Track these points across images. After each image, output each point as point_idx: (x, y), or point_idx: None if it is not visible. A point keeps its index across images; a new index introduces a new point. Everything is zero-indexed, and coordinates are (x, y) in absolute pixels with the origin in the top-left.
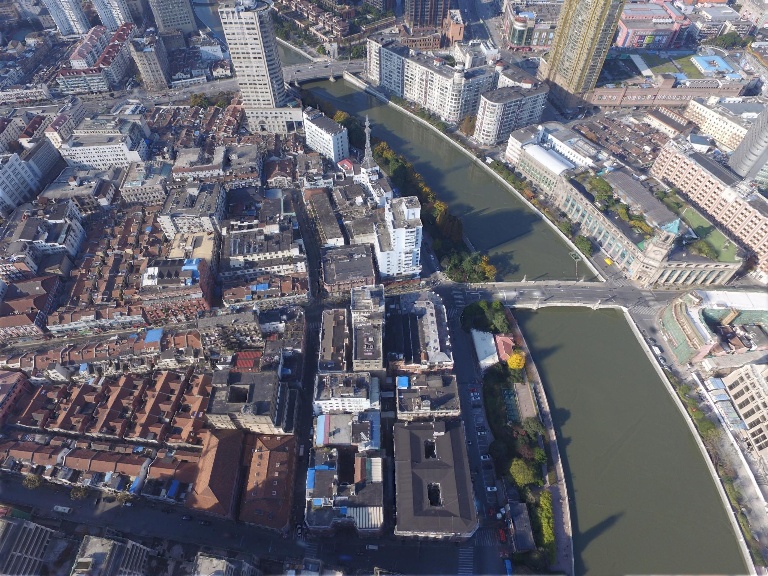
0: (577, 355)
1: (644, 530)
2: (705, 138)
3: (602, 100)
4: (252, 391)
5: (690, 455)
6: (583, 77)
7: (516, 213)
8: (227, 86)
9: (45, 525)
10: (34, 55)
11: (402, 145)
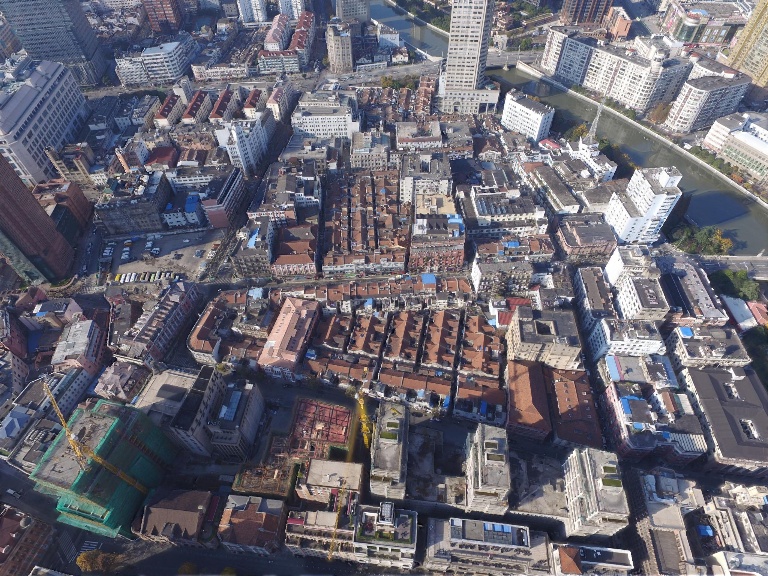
0: None
1: None
2: None
3: None
4: (556, 326)
5: None
6: None
7: (728, 195)
8: (408, 71)
9: None
10: (227, 39)
11: None
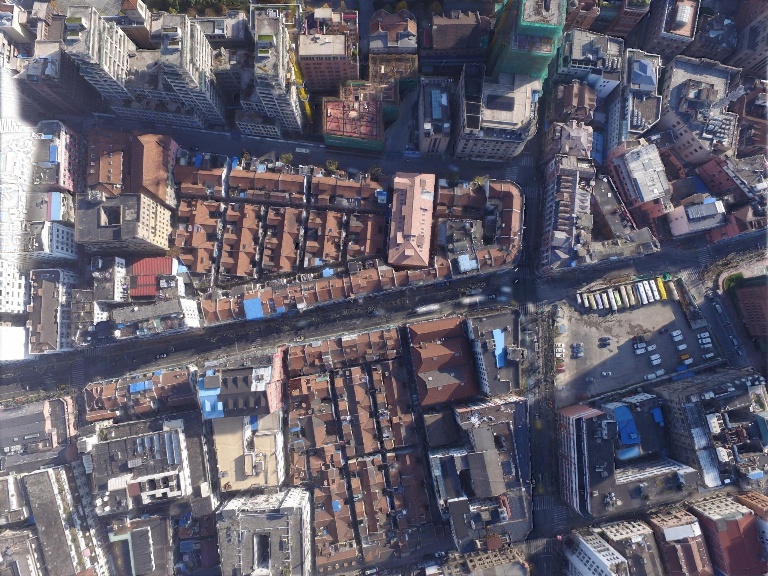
0: None
1: None
2: None
3: None
4: (99, 220)
5: None
6: None
7: None
8: None
9: (315, 141)
10: None
11: None
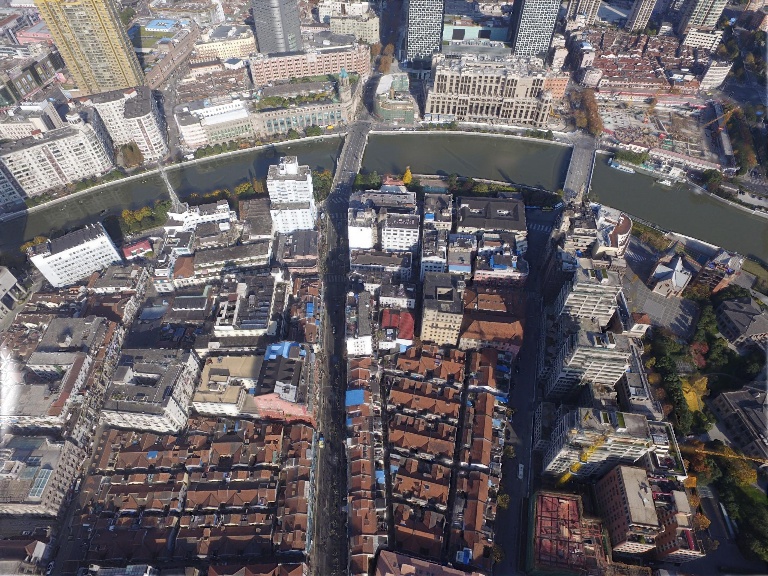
0: (400, 158)
1: (503, 163)
2: (233, 59)
3: (154, 83)
4: None
5: (461, 142)
6: (135, 72)
7: (262, 157)
8: None
9: (534, 488)
10: None
11: (121, 210)
